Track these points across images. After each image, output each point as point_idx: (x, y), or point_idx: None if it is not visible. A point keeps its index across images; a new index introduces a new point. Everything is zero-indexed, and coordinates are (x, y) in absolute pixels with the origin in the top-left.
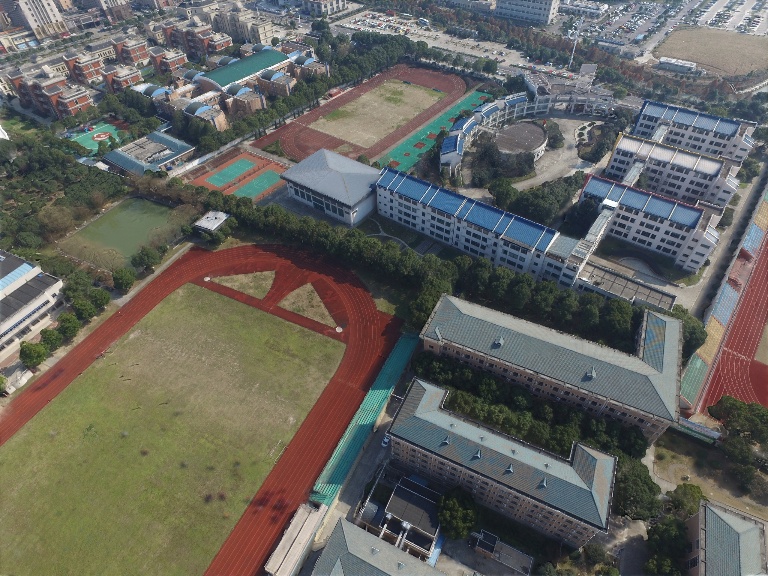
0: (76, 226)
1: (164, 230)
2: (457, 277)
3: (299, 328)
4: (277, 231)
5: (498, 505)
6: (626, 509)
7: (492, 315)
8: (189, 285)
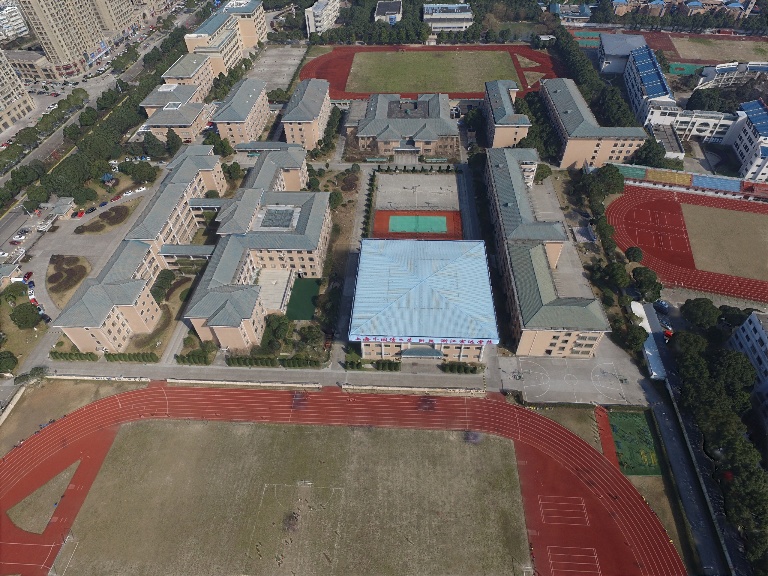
0: (504, 21)
1: (524, 29)
2: (599, 94)
3: (518, 79)
4: (563, 51)
5: None
6: None
7: (573, 88)
8: (507, 52)
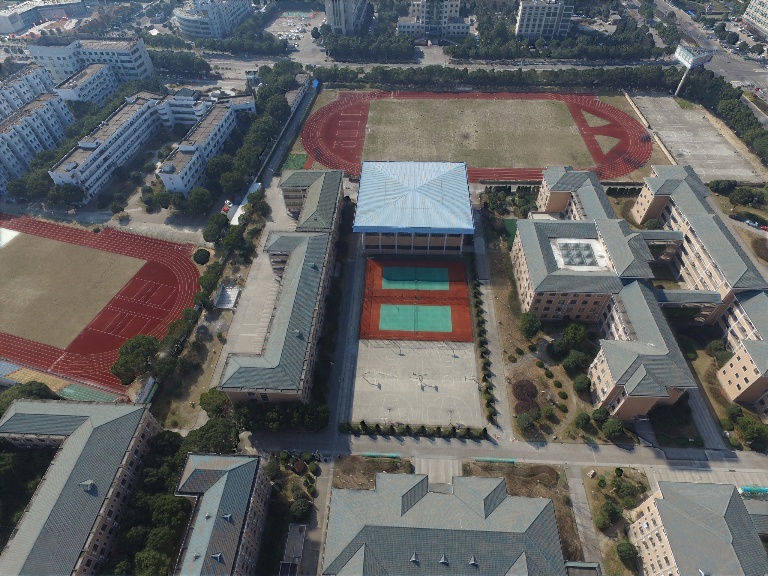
0: None
1: None
2: None
3: None
4: None
5: (249, 571)
6: (232, 446)
7: None
8: None
